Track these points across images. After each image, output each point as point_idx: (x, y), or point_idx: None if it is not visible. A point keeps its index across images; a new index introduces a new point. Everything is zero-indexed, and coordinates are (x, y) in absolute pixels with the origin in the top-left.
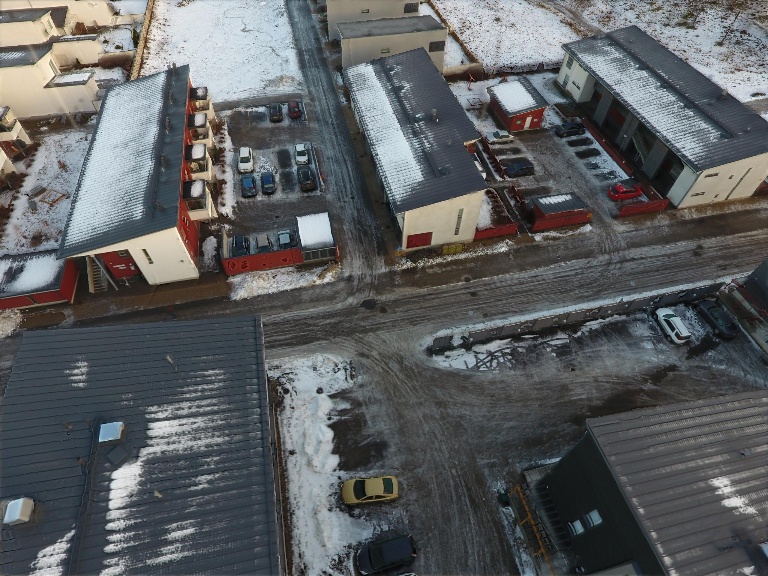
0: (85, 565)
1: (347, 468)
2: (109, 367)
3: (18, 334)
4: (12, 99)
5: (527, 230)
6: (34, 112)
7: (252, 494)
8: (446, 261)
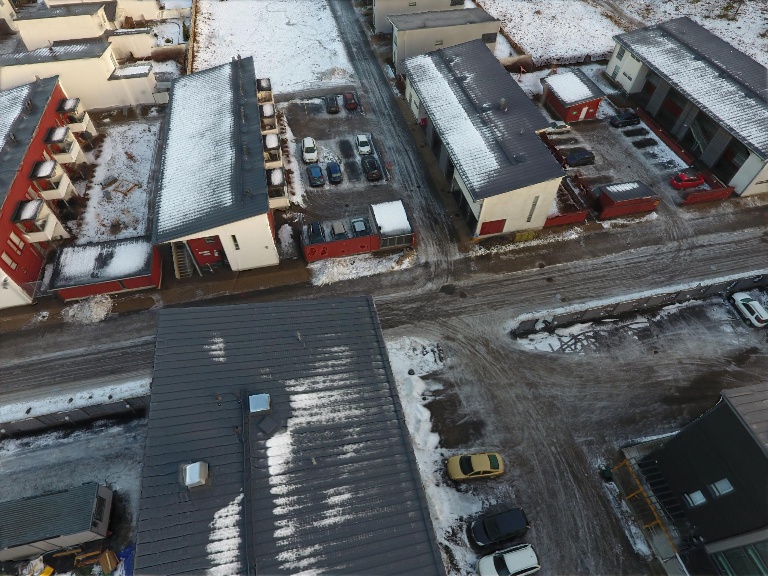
0: (259, 525)
1: (448, 445)
2: (243, 343)
3: (111, 318)
4: (76, 91)
5: (594, 218)
6: (96, 104)
7: (397, 462)
8: (518, 248)
